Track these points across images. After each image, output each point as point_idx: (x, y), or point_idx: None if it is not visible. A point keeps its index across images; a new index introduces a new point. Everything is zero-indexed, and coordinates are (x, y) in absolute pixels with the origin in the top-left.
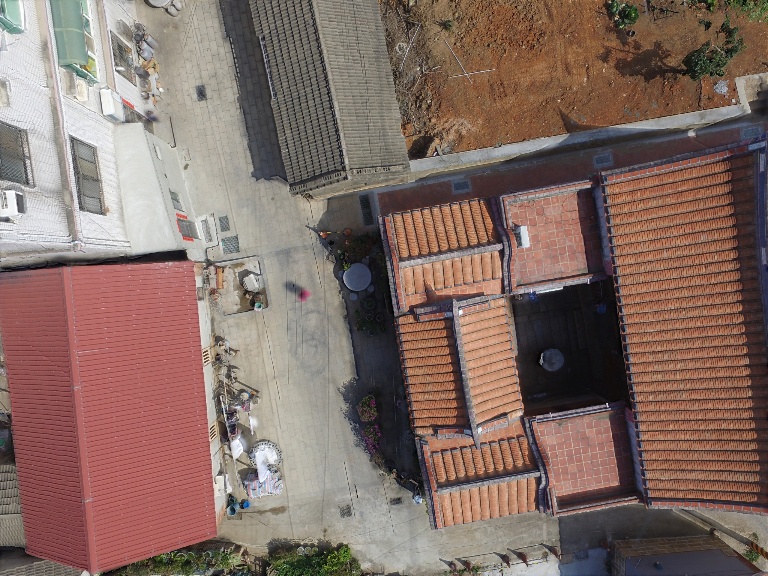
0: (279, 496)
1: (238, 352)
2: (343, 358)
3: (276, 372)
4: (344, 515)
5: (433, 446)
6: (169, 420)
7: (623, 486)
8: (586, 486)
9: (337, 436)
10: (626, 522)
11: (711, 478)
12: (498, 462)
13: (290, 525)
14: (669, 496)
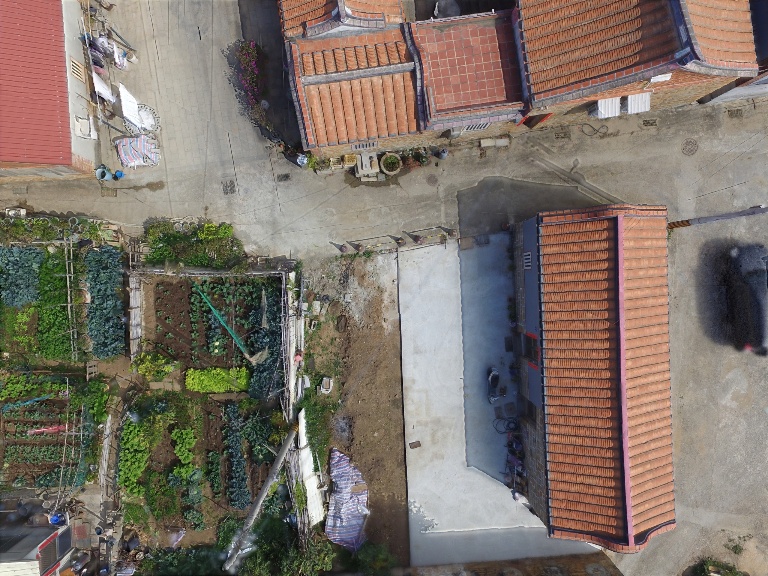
0: (157, 168)
1: (114, 7)
2: (228, 18)
3: (155, 31)
4: (227, 192)
5: (304, 49)
6: (16, 17)
7: (510, 101)
8: (470, 100)
9: (220, 103)
10: (529, 203)
11: (594, 52)
12: (372, 60)
13: (169, 202)
14: (552, 86)
